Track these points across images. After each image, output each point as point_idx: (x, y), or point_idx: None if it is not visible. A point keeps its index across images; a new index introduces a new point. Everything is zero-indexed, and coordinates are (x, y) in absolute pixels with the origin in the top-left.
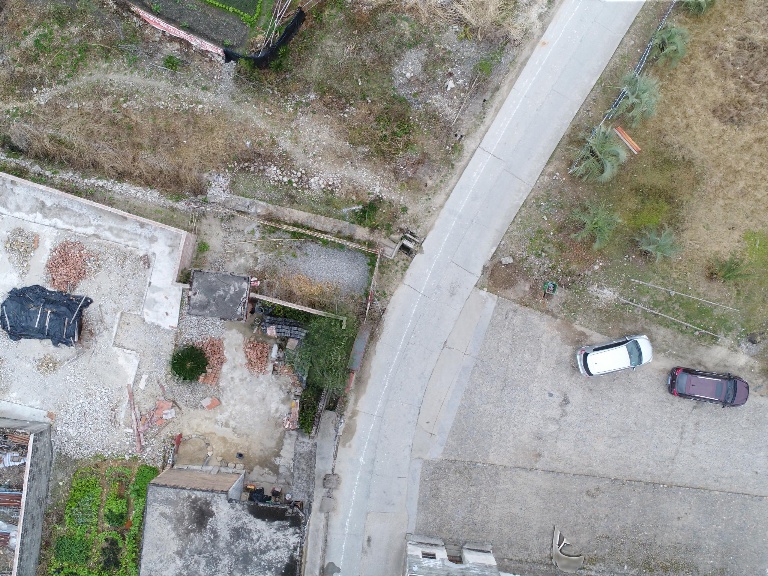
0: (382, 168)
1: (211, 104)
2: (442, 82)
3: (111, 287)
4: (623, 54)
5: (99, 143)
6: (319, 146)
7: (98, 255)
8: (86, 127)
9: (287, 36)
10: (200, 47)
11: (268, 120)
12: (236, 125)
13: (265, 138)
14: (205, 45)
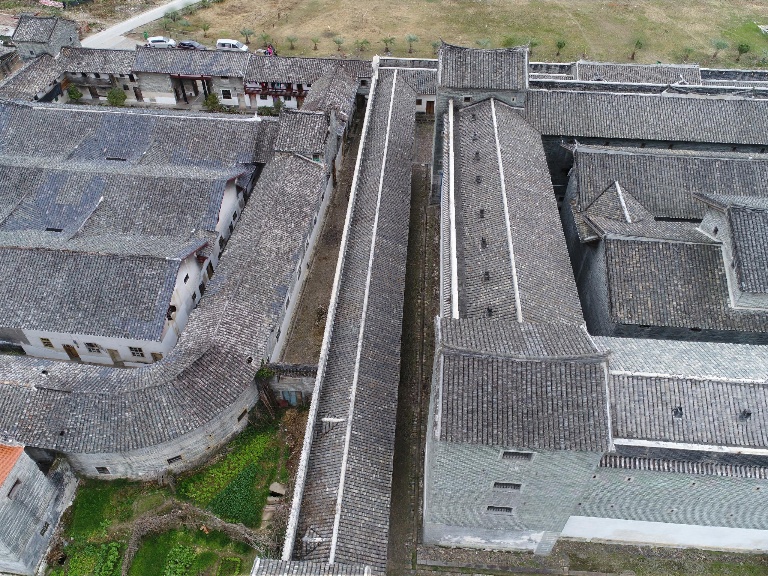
0: (101, 19)
1: (53, 12)
2: (130, 8)
3: None
4: (192, 7)
5: None
6: None
7: None
8: (8, 12)
9: (85, 3)
10: (57, 7)
11: None
12: None
13: None
14: (58, 5)
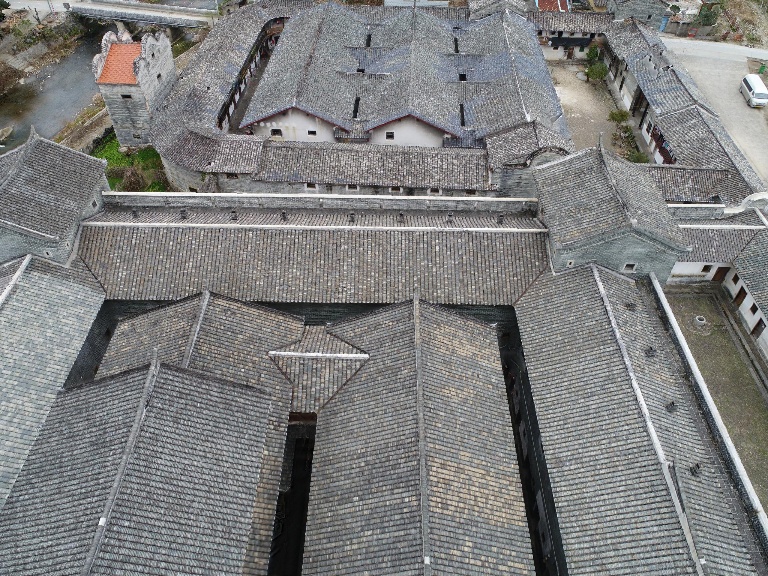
0: None
1: (762, 18)
2: None
3: (686, 4)
4: None
5: (730, 2)
6: (767, 32)
7: (694, 2)
8: None
9: None
10: None
11: (767, 25)
12: (759, 21)
13: (760, 25)
14: None
